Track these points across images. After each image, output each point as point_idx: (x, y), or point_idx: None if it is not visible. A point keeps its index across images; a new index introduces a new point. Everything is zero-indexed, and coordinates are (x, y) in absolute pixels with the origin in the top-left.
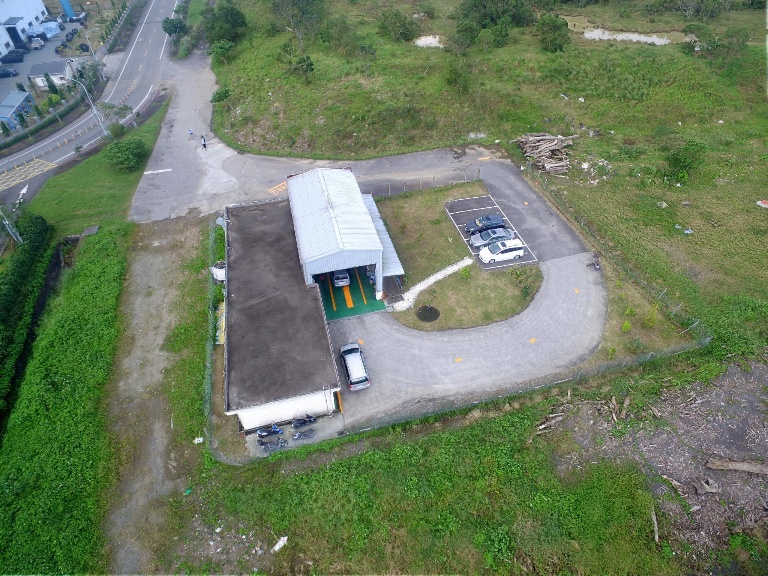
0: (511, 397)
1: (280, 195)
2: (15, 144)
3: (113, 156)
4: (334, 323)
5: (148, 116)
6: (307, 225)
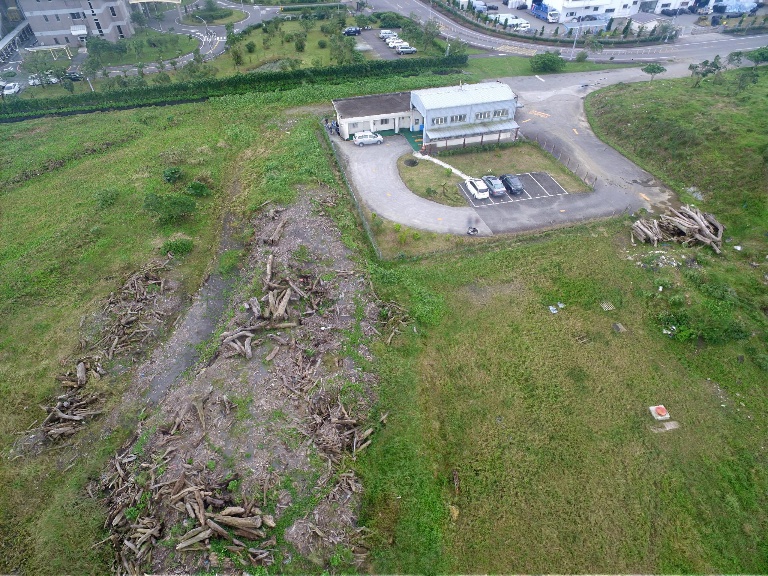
0: None
1: (528, 114)
2: (551, 42)
3: (535, 57)
4: (402, 137)
5: (616, 63)
6: None
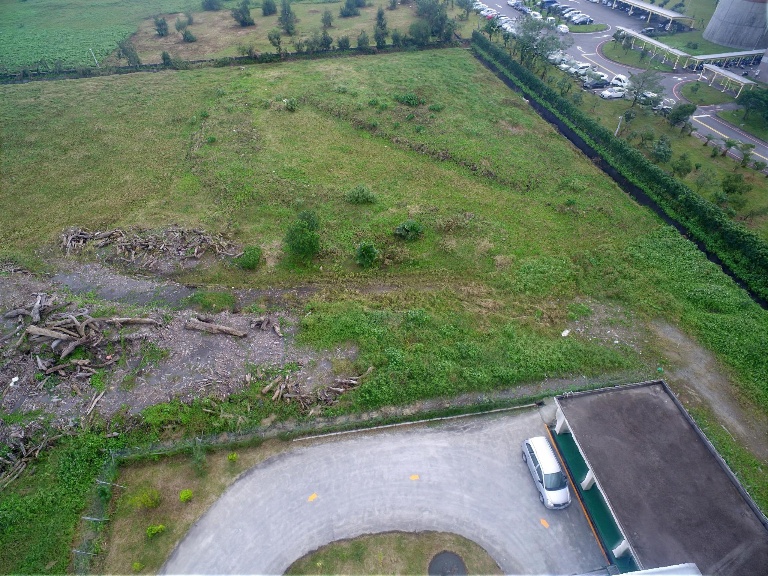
0: None
1: None
2: None
3: None
4: (596, 568)
5: None
6: None
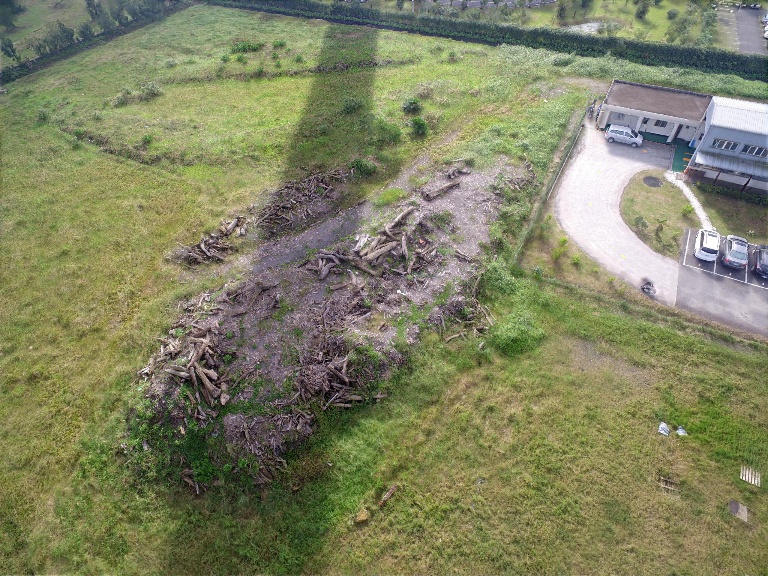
0: None
1: None
2: None
3: None
4: (671, 149)
5: None
6: (764, 106)
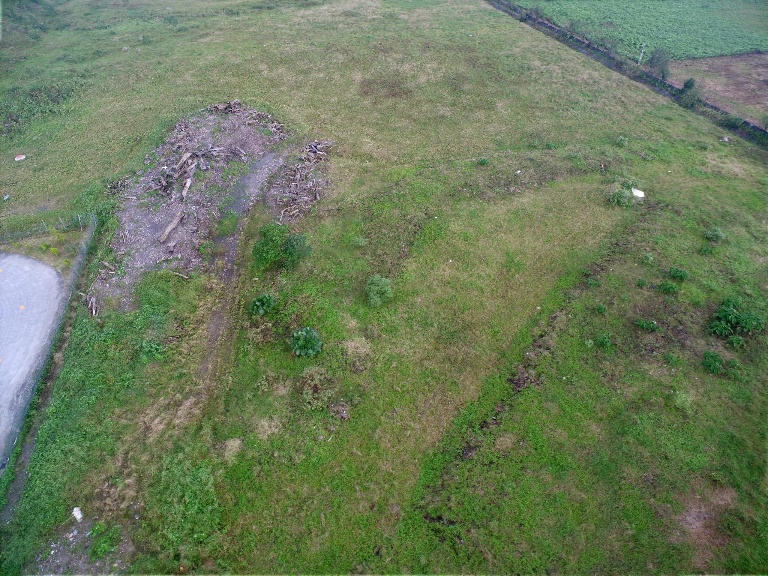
0: (60, 329)
1: None
2: None
3: None
4: None
5: None
6: None
